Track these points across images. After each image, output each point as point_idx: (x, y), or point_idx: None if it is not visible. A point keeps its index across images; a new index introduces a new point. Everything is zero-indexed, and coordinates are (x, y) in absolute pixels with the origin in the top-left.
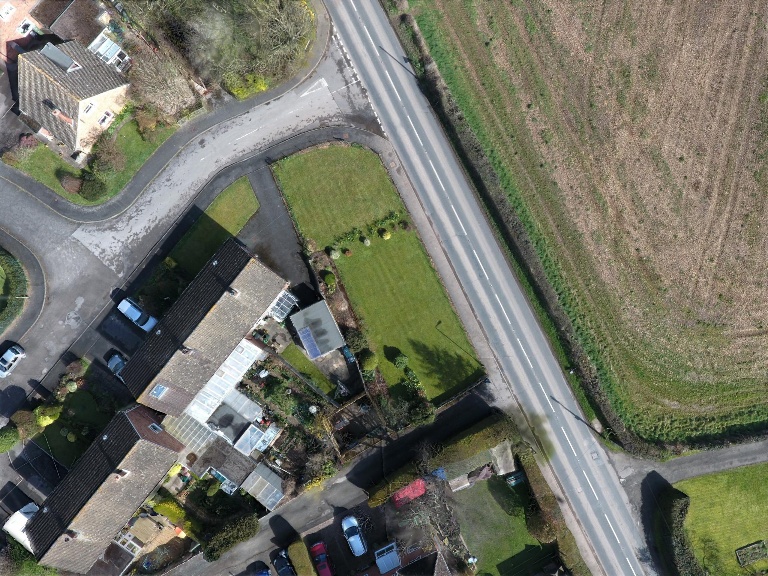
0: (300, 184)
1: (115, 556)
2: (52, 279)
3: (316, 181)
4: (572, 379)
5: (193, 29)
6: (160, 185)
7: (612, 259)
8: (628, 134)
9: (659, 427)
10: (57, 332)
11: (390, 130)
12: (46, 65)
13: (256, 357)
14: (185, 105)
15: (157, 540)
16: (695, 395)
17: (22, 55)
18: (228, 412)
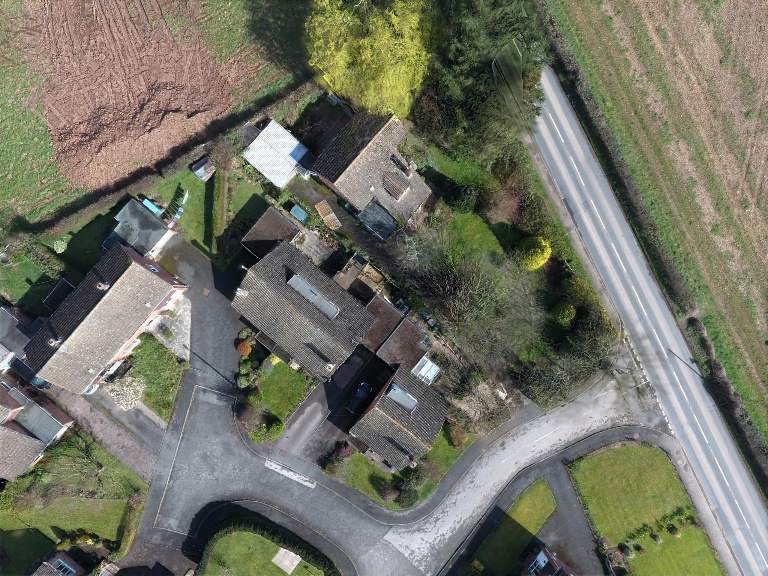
0: (594, 483)
1: None
2: None
3: (609, 480)
4: None
5: (495, 337)
6: (464, 487)
7: None
8: None
9: None
10: None
11: (677, 428)
12: (396, 411)
13: None
14: (488, 410)
15: None
16: None
17: (378, 407)
18: None
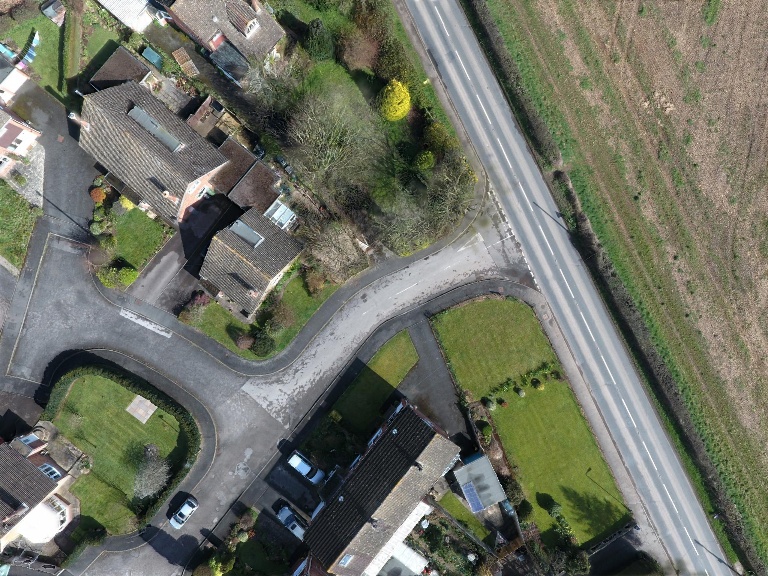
0: (457, 337)
1: None
2: (222, 431)
3: (472, 333)
4: (716, 523)
5: (356, 188)
6: (324, 339)
7: (753, 405)
8: None
9: None
10: (227, 482)
11: (543, 283)
12: (237, 243)
13: (424, 513)
14: (348, 261)
15: None
16: None
17: (216, 236)
18: (396, 565)
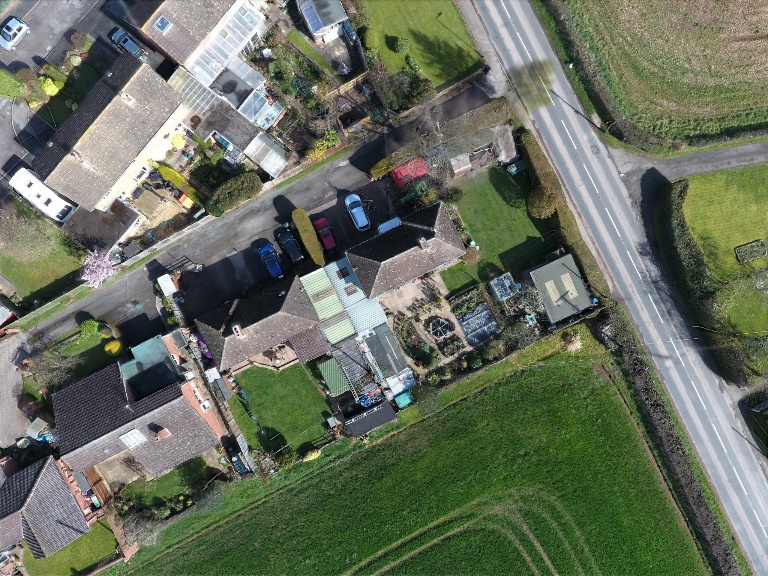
0: None
1: (120, 213)
2: None
3: None
4: (571, 73)
5: None
6: None
7: None
8: None
9: (658, 126)
10: (61, 11)
11: None
12: None
13: (259, 23)
14: None
15: (162, 215)
16: (693, 96)
17: None
18: (232, 78)
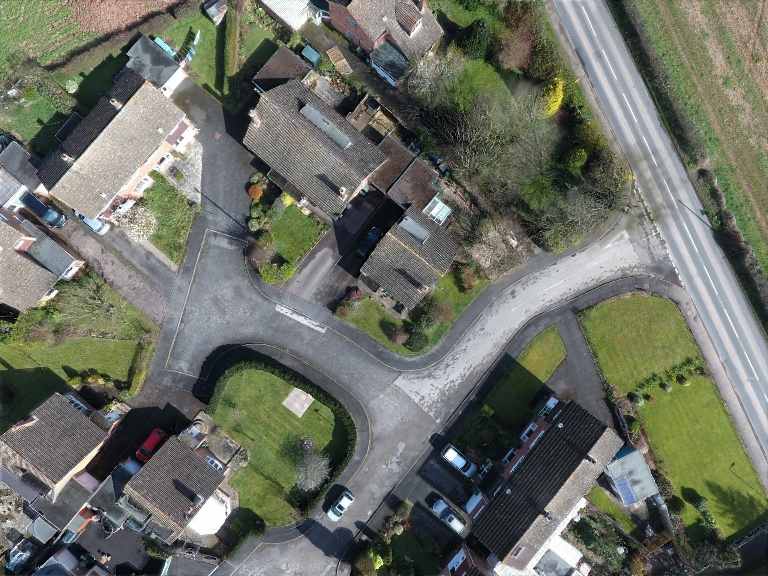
0: (604, 333)
1: None
2: (376, 425)
3: (619, 330)
4: None
5: (506, 185)
6: (474, 334)
7: None
8: None
9: None
10: (381, 476)
11: (687, 280)
12: (408, 240)
13: (580, 506)
14: (498, 258)
15: None
16: None
17: (390, 232)
18: (553, 558)
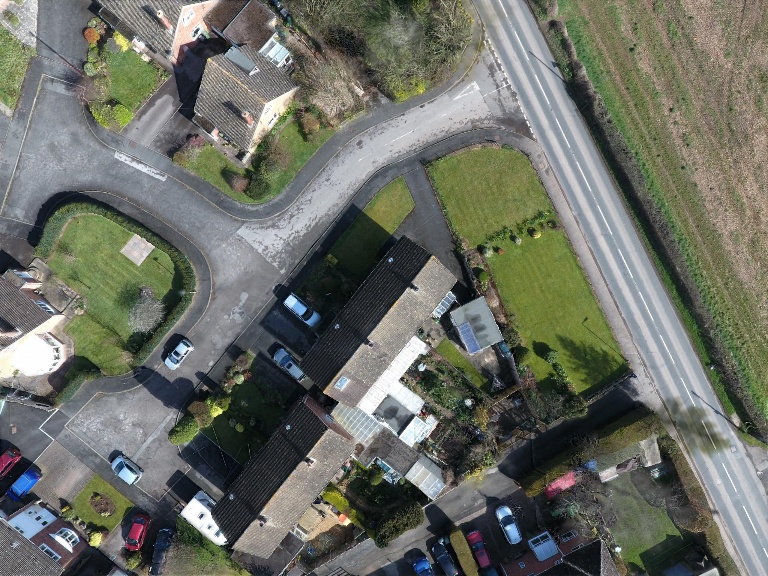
0: (453, 184)
1: (287, 542)
2: (218, 275)
3: (469, 181)
4: (712, 375)
5: (352, 34)
6: (320, 184)
7: (749, 259)
8: (765, 137)
9: None
10: (223, 326)
11: (539, 132)
12: (232, 68)
13: (420, 351)
14: (344, 107)
15: (319, 528)
16: None
17: (211, 59)
18: (393, 404)
